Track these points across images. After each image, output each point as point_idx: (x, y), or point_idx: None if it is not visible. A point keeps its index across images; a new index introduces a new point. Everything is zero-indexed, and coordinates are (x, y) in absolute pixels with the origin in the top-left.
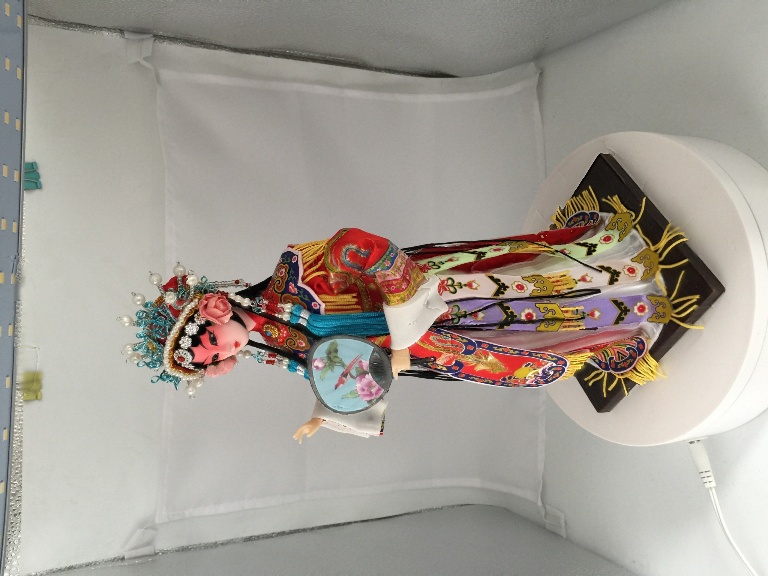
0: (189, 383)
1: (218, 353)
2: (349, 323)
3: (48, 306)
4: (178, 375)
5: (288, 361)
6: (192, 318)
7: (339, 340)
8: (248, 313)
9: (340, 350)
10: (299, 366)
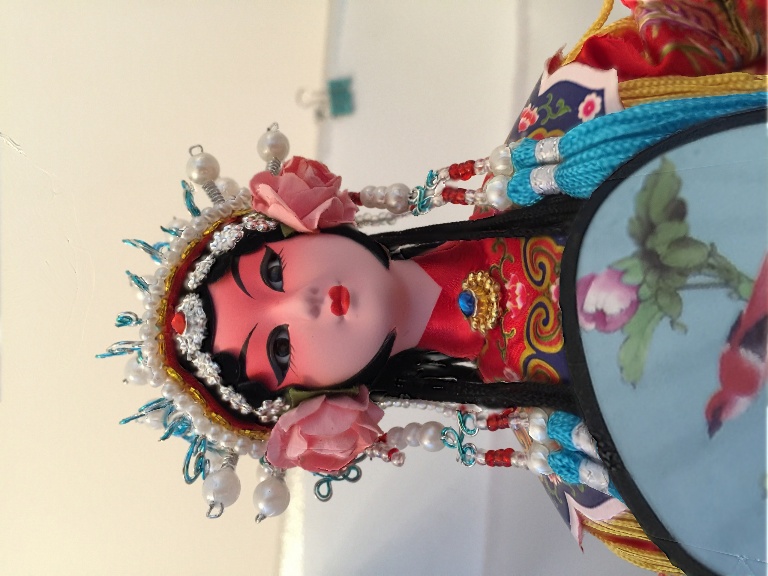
0: (226, 463)
1: (287, 326)
2: (734, 108)
3: (2, 201)
4: (185, 405)
5: (544, 424)
6: (241, 219)
7: (682, 153)
8: (422, 262)
9: (696, 201)
10: (578, 428)
